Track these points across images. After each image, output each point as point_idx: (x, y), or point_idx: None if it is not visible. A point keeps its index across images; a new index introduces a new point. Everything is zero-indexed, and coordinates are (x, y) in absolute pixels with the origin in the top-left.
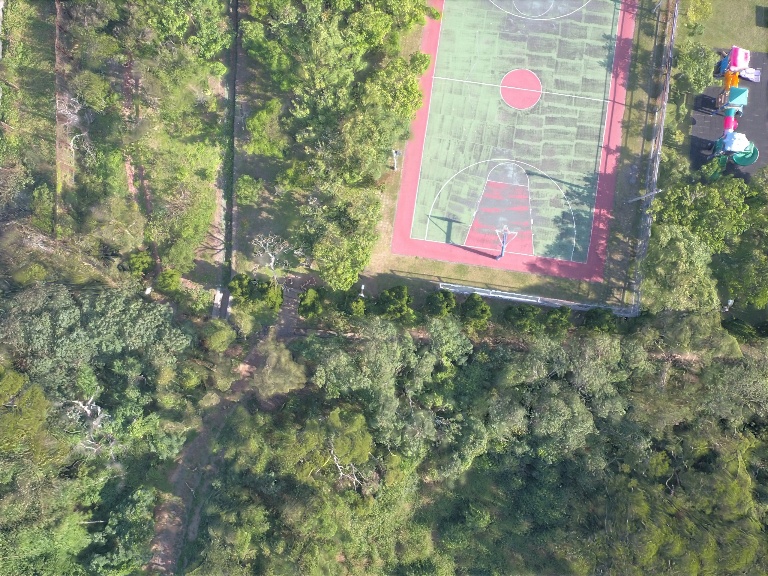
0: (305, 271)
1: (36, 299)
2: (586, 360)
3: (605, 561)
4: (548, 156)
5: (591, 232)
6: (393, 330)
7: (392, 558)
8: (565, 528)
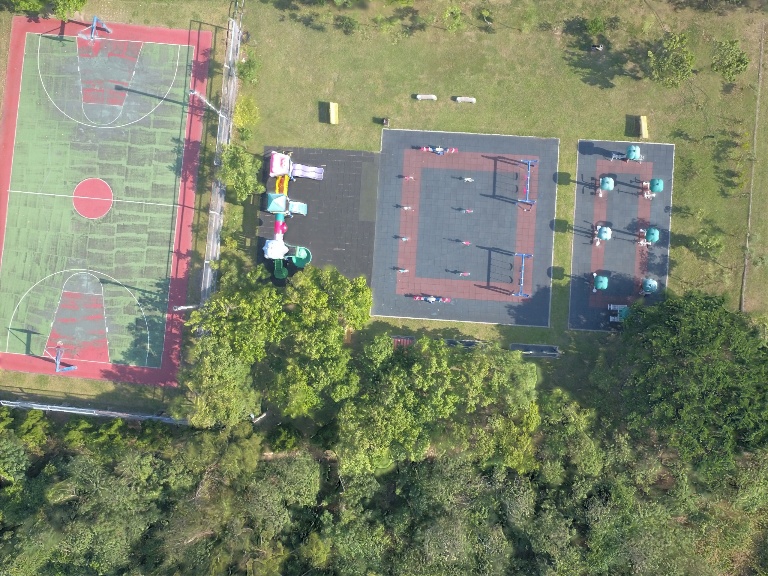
0: None
1: None
2: (119, 476)
3: None
4: (121, 264)
5: (164, 337)
6: None
7: None
8: None
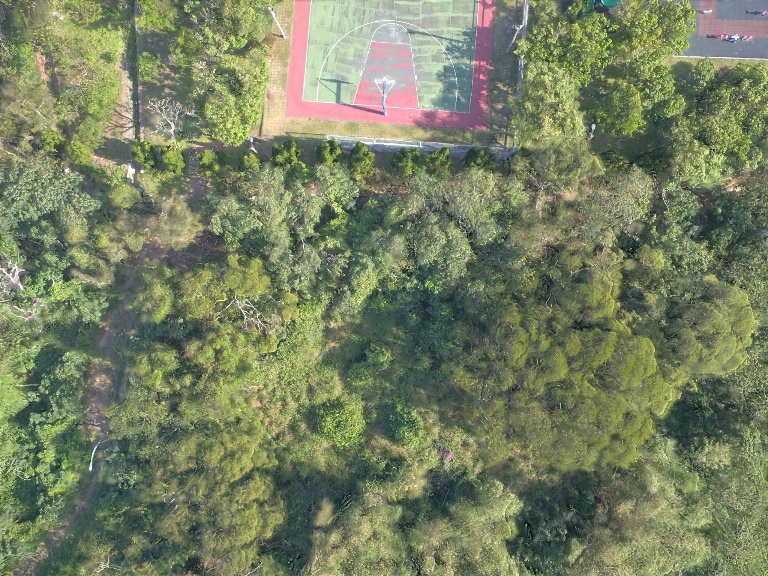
0: (208, 141)
1: None
2: (461, 191)
3: (485, 371)
4: (428, 14)
5: (472, 83)
6: (280, 175)
7: (303, 399)
8: None
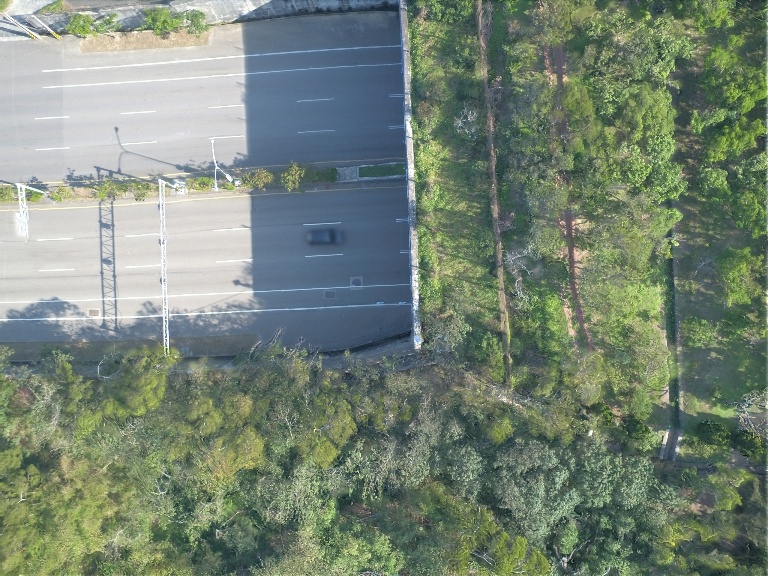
0: (759, 410)
1: (523, 461)
2: None
3: None
4: None
5: None
6: None
7: None
8: None
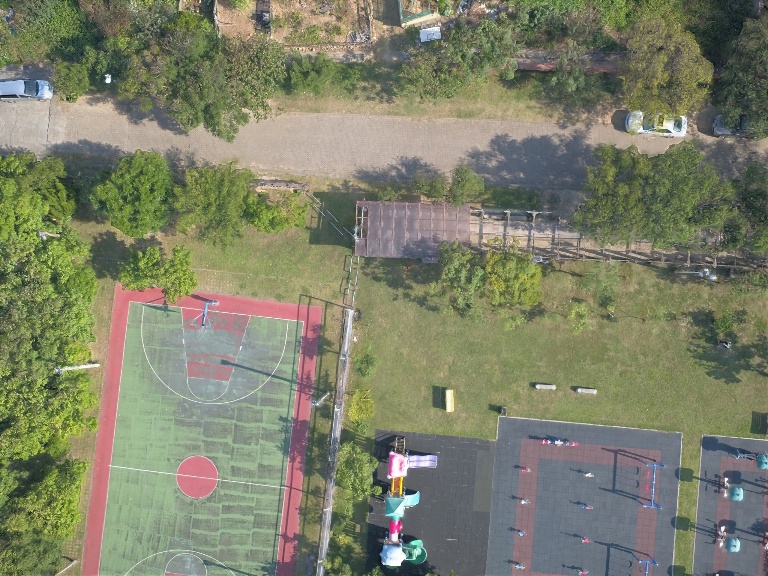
0: None
1: None
2: None
3: None
4: (225, 546)
5: None
6: None
7: None
8: None
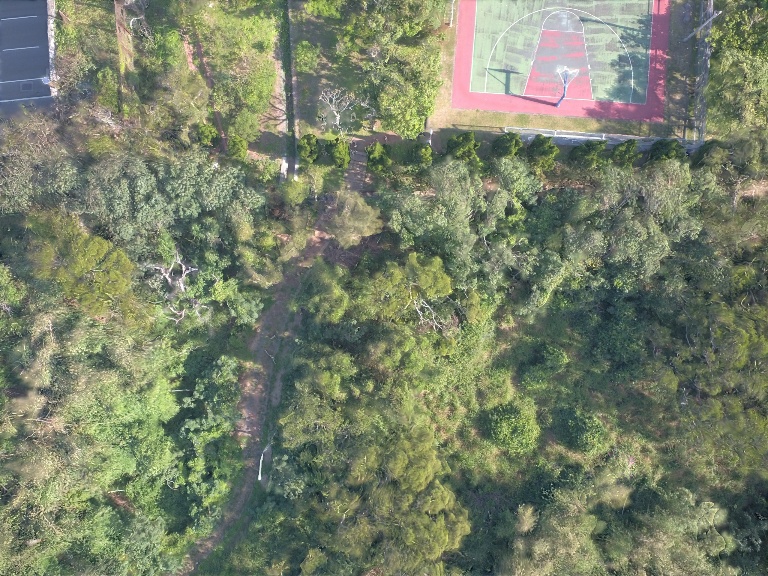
0: (368, 134)
1: (112, 170)
2: (656, 185)
3: (689, 374)
4: (601, 1)
5: (648, 73)
6: (465, 169)
7: (473, 404)
8: (641, 362)
